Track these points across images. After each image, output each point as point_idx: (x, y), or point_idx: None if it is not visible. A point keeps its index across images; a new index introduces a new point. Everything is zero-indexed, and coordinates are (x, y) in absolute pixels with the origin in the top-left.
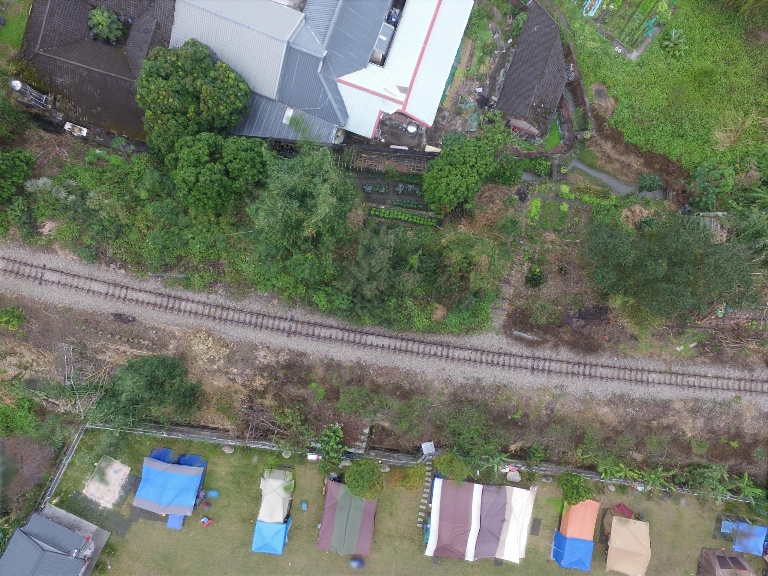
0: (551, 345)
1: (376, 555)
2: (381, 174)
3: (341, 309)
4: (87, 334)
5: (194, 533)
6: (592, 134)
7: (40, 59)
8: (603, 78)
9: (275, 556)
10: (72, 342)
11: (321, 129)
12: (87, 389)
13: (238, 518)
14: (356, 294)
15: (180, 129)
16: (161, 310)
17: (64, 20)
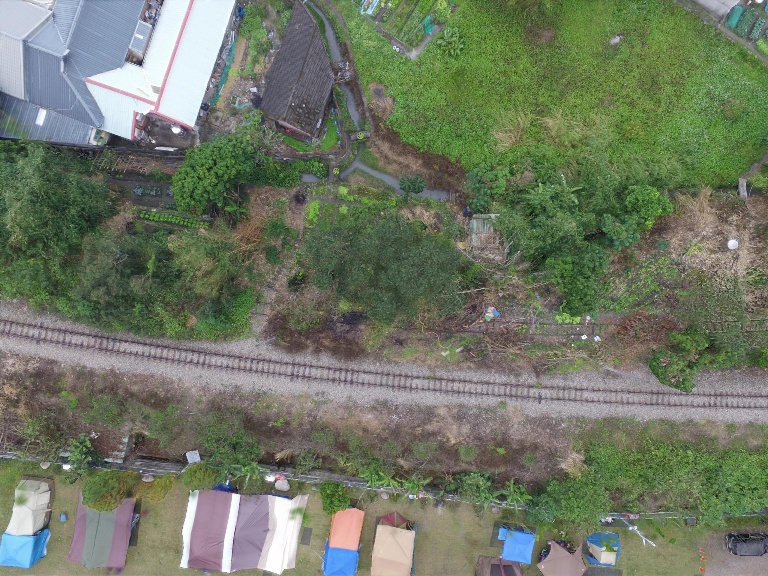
0: (311, 351)
1: (140, 567)
2: (152, 176)
3: (87, 315)
4: None
5: None
6: (366, 135)
7: None
8: (379, 77)
9: (34, 569)
10: None
11: (76, 130)
12: None
13: None
14: None
15: None
16: None
17: None
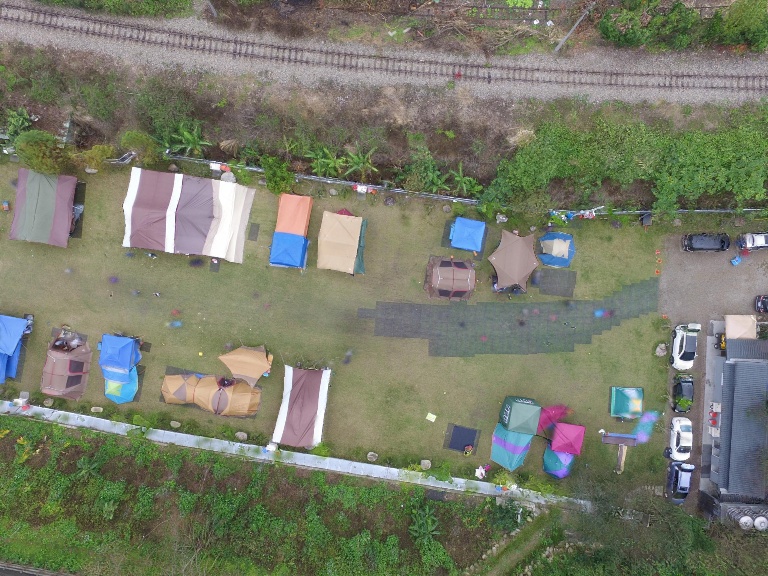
0: (253, 27)
1: (85, 259)
2: None
3: None
4: None
5: None
6: None
7: None
8: None
9: None
10: None
11: None
12: None
13: None
14: None
15: None
16: None
17: None
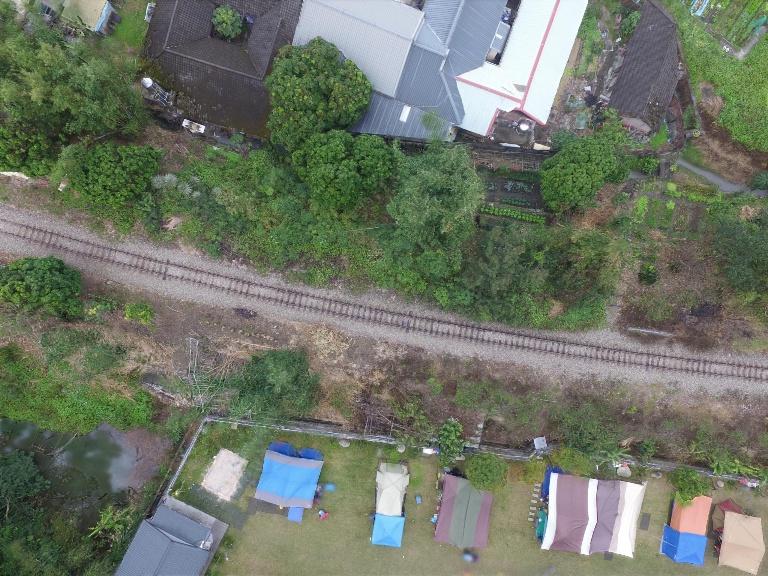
0: (666, 342)
1: (488, 549)
2: (490, 172)
3: (461, 305)
4: (210, 329)
5: (310, 526)
6: (701, 133)
7: (167, 57)
8: (711, 77)
9: (389, 549)
10: (194, 336)
11: (437, 127)
12: (208, 383)
13: (353, 511)
14: (477, 290)
15: (310, 126)
16: (282, 305)
17: (189, 18)
